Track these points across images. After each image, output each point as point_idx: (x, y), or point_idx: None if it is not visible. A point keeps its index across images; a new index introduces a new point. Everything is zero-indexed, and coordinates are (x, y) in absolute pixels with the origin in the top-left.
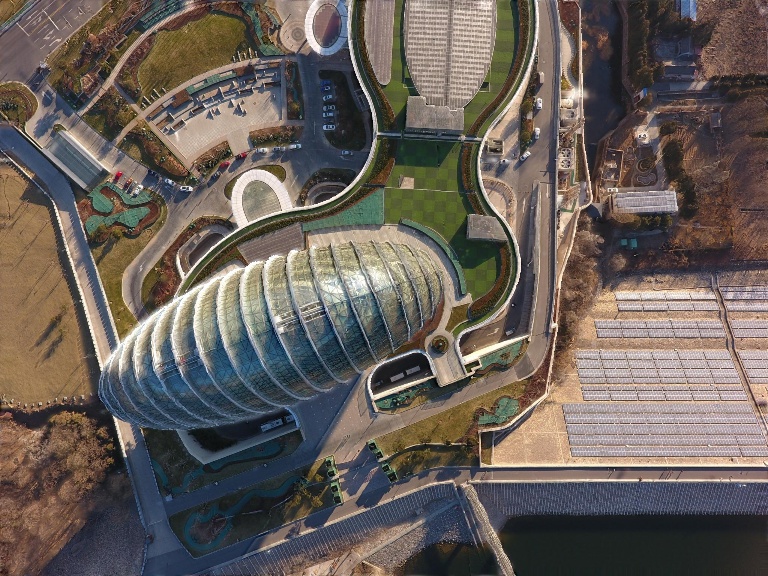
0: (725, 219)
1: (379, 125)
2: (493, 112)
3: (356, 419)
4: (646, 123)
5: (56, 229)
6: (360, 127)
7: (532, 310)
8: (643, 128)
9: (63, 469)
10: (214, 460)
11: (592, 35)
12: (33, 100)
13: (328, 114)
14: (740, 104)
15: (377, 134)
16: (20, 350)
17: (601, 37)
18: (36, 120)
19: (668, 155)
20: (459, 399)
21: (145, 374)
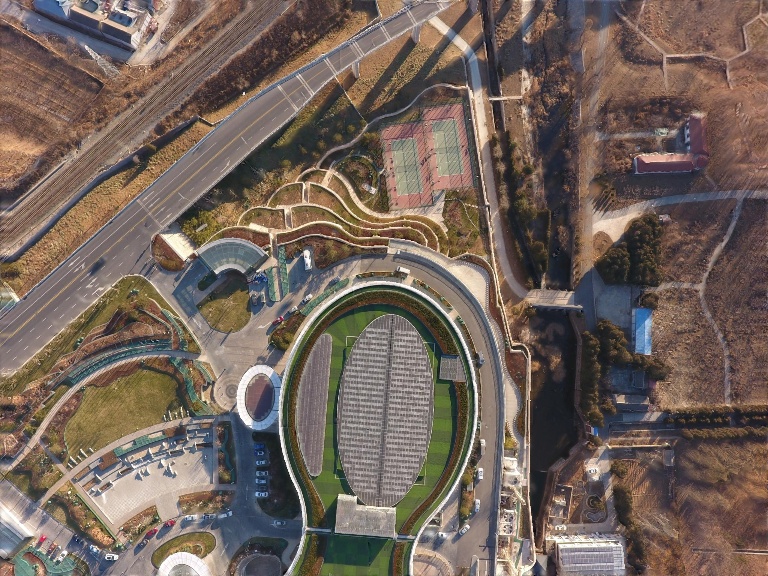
0: (675, 570)
1: (308, 520)
2: (427, 508)
3: None
4: (597, 456)
5: None
6: (294, 494)
7: None
8: (594, 461)
9: None
10: None
11: (545, 355)
12: None
13: (261, 481)
14: (693, 451)
15: (306, 529)
16: None
17: (554, 358)
18: None
19: (618, 498)
20: None
21: None
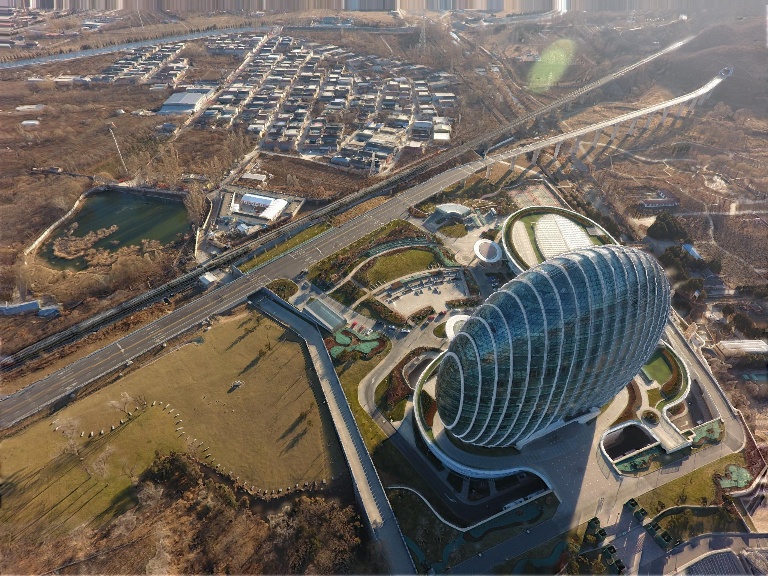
0: None
1: None
2: None
3: (604, 482)
4: (709, 310)
5: (306, 356)
6: None
7: (710, 401)
8: (709, 313)
9: (308, 548)
10: (474, 526)
11: None
12: (295, 287)
13: None
14: (767, 296)
15: None
16: (267, 441)
17: None
18: (296, 296)
19: (739, 324)
20: (690, 466)
21: (535, 281)
